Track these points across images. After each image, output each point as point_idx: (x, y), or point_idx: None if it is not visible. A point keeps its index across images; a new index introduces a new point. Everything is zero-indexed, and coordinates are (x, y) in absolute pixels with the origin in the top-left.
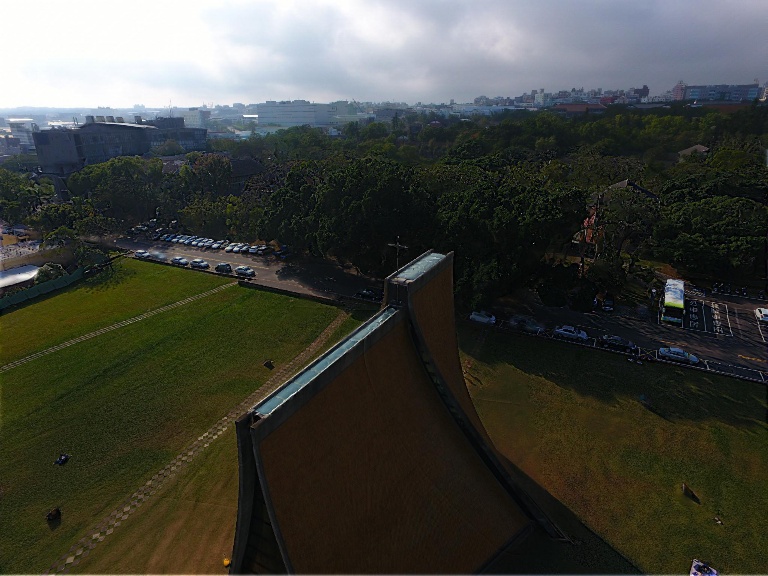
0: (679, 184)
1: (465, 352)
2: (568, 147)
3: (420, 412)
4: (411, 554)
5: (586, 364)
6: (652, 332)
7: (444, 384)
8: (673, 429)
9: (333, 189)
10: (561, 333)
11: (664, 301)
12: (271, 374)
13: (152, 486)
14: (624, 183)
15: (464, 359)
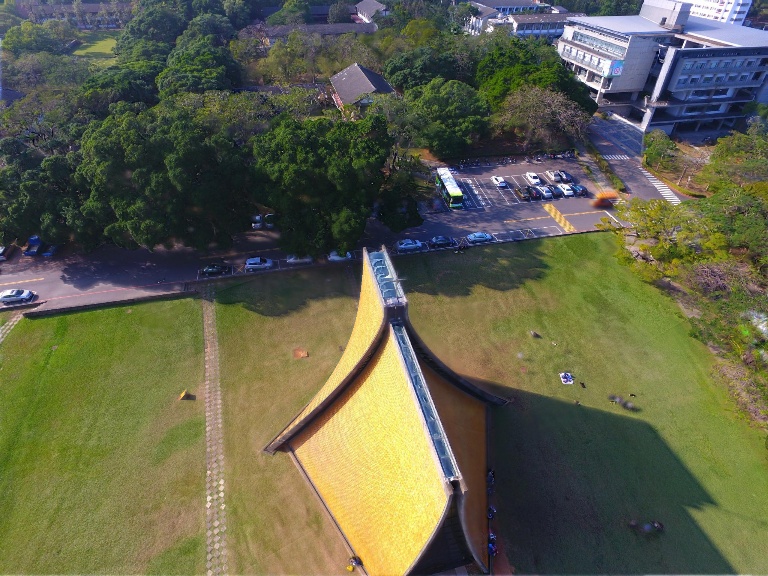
0: (399, 65)
1: (349, 295)
2: (273, 18)
3: (430, 385)
4: (471, 474)
5: (434, 268)
6: (452, 221)
7: (434, 357)
8: (505, 295)
9: (109, 162)
10: (404, 248)
11: (448, 192)
12: (201, 404)
13: (217, 573)
14: (358, 70)
15: (353, 302)
